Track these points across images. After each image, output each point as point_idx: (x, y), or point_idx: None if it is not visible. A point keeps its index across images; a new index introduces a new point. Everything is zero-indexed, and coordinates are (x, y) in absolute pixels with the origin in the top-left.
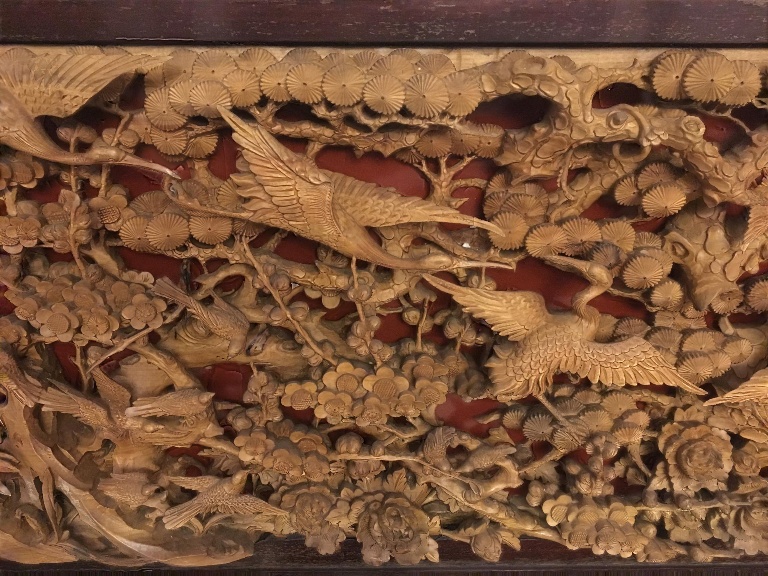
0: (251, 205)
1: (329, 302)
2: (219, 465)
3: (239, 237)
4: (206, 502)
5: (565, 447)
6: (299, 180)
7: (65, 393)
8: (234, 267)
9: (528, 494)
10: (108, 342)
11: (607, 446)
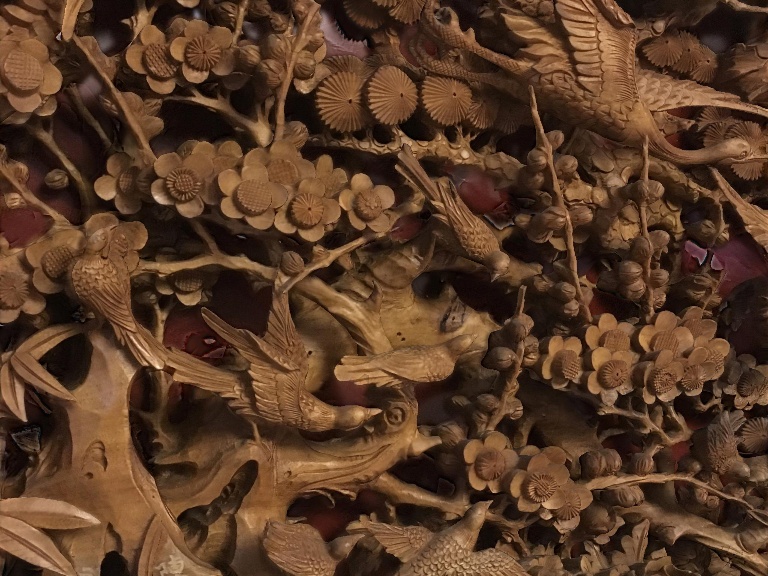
0: (535, 50)
1: (557, 244)
2: (382, 546)
3: (461, 131)
4: (425, 573)
5: None
6: (601, 19)
7: (200, 359)
8: (444, 180)
9: None
10: (273, 274)
11: None
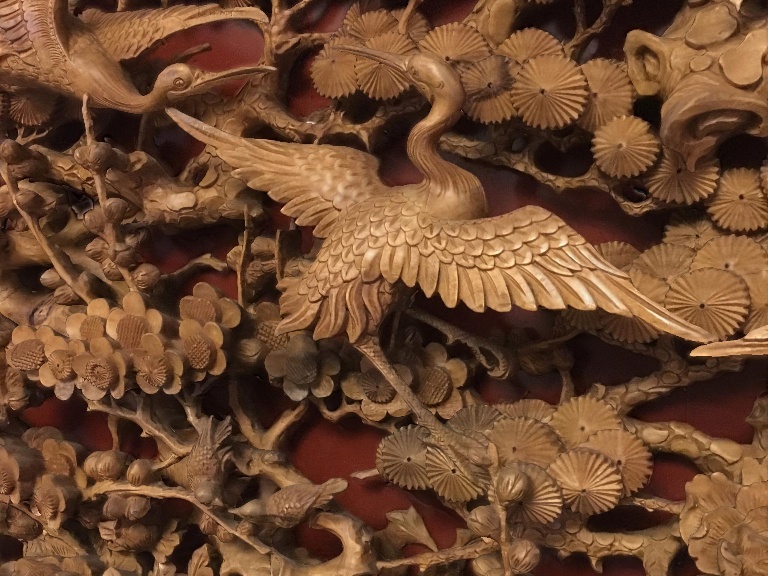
0: None
1: None
2: None
3: (23, 132)
4: None
5: (451, 496)
6: None
7: None
8: (21, 181)
9: None
10: None
11: (503, 471)
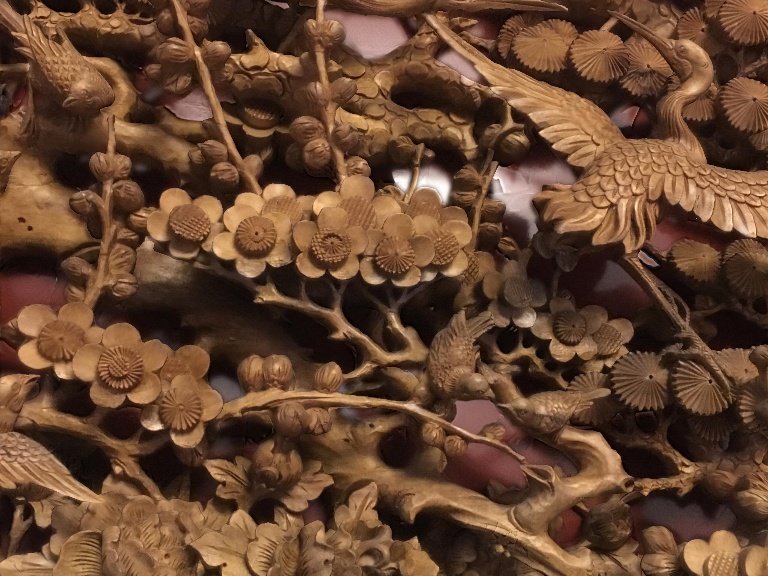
0: None
1: (255, 132)
2: None
3: (124, 7)
4: None
5: (699, 409)
6: None
7: None
8: (101, 59)
9: (643, 557)
10: None
11: None
